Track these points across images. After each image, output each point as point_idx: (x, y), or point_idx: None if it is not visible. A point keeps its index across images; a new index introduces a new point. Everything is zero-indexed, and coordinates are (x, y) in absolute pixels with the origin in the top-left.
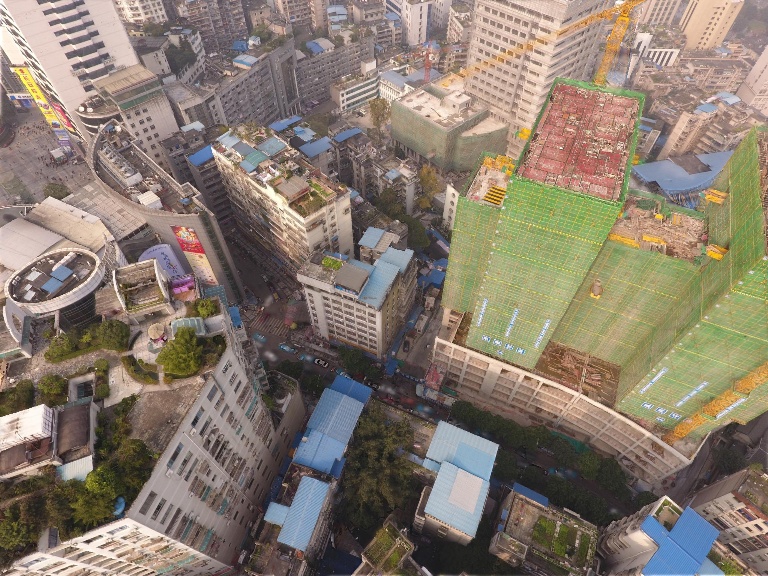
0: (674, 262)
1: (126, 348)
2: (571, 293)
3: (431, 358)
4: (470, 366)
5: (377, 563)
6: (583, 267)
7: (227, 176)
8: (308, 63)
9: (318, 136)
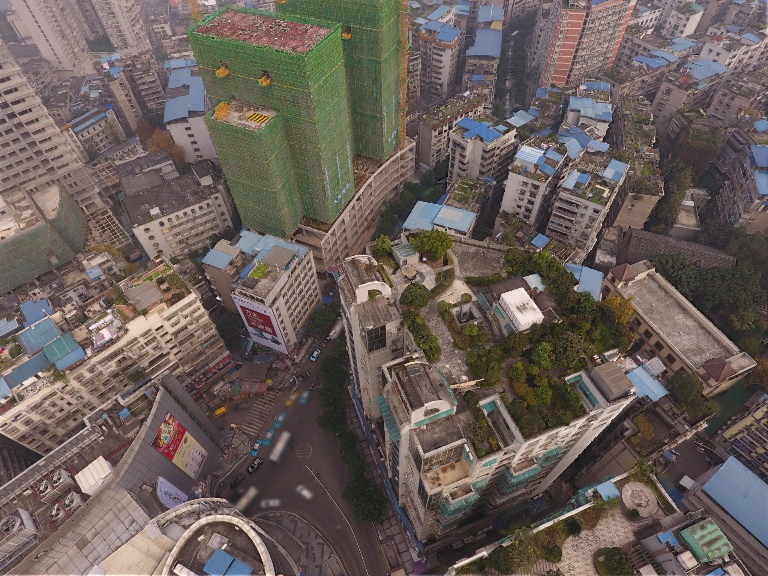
0: None
1: None
2: None
3: None
4: (339, 237)
5: None
6: (344, 84)
7: (42, 421)
8: None
9: (11, 316)
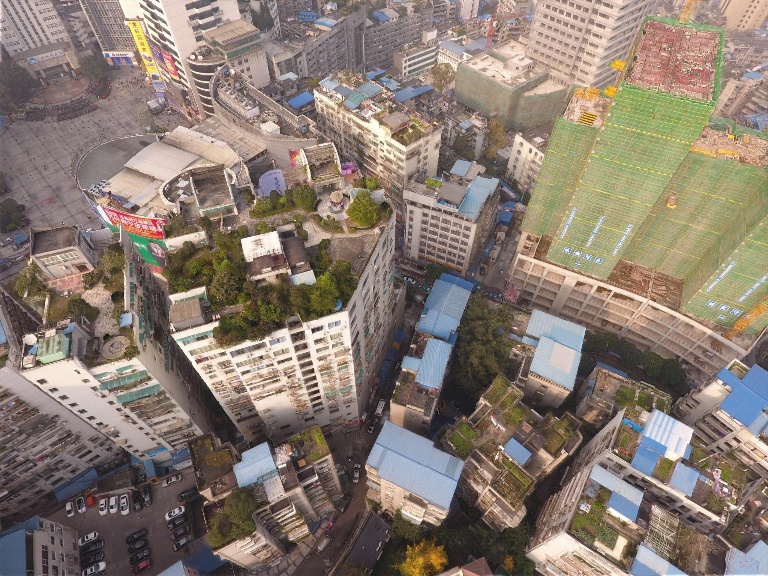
0: (747, 169)
1: (313, 209)
2: (657, 195)
3: (508, 278)
4: (546, 281)
5: (495, 404)
6: (672, 168)
7: (325, 117)
8: (375, 31)
9: (402, 86)
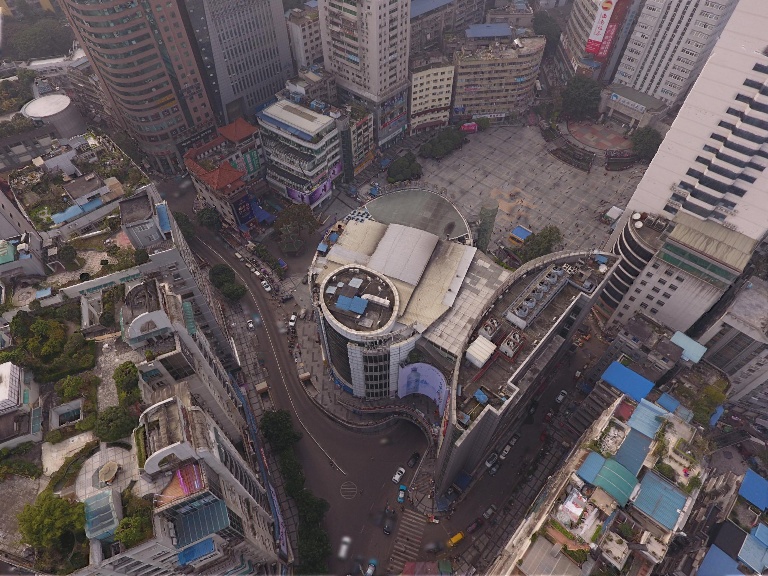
0: None
1: None
2: None
3: None
4: None
5: None
6: None
7: None
8: None
9: None
